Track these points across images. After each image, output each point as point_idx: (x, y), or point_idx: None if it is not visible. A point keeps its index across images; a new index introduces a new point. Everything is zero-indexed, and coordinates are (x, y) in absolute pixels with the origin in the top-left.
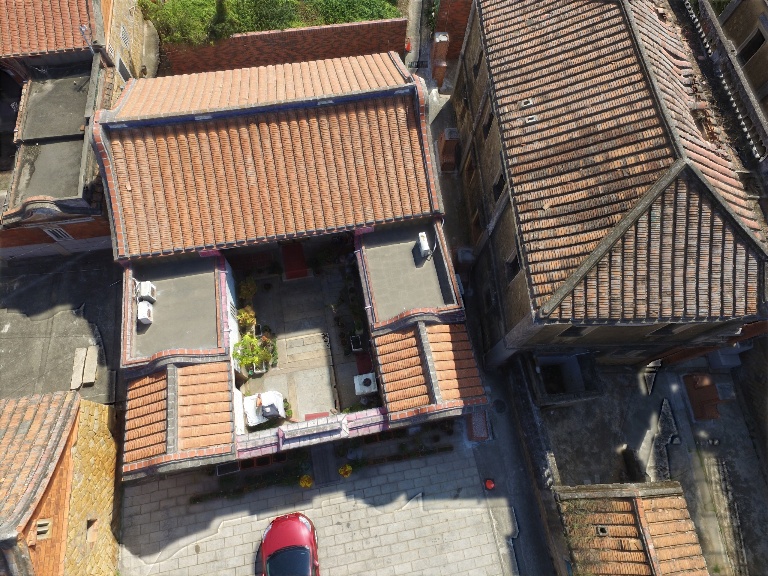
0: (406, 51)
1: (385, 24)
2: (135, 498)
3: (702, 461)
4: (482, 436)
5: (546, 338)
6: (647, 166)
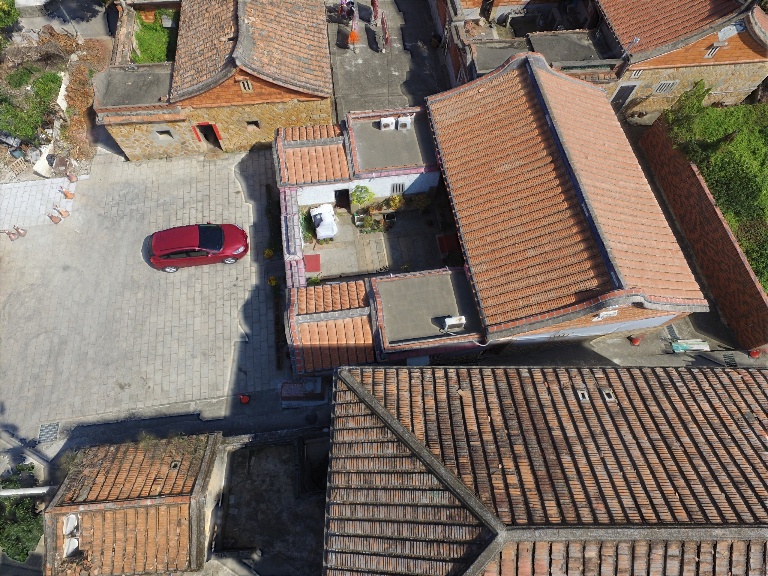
0: (749, 352)
1: (767, 312)
2: None
3: None
4: (283, 391)
5: None
6: (501, 493)
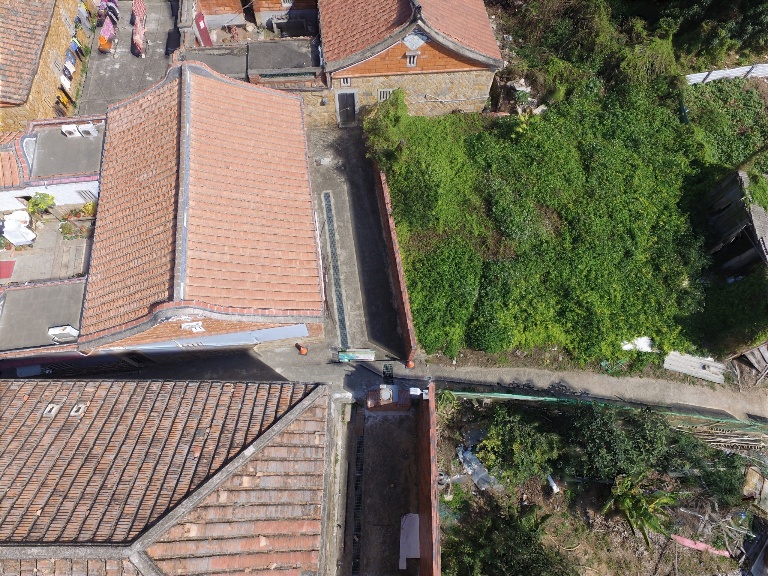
0: (407, 362)
1: None
2: None
3: None
4: None
5: None
6: None
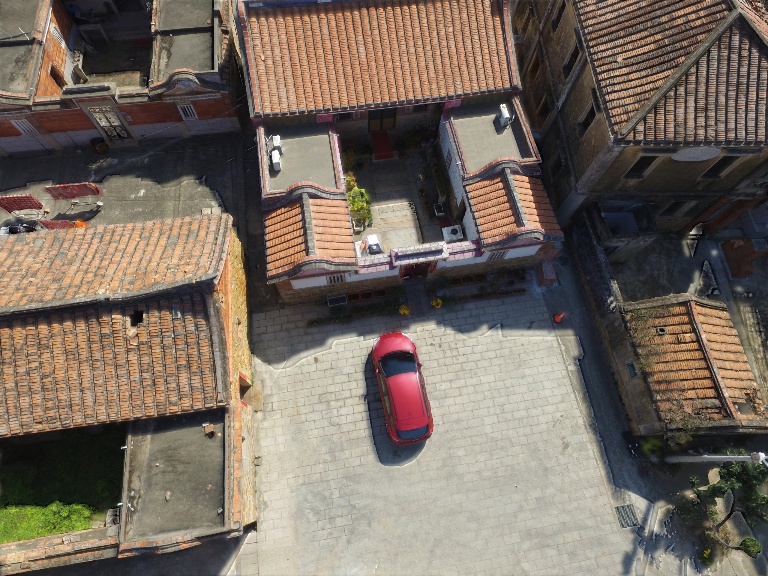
0: None
1: None
2: (261, 321)
3: (738, 308)
4: (551, 278)
5: (613, 180)
6: (706, 19)
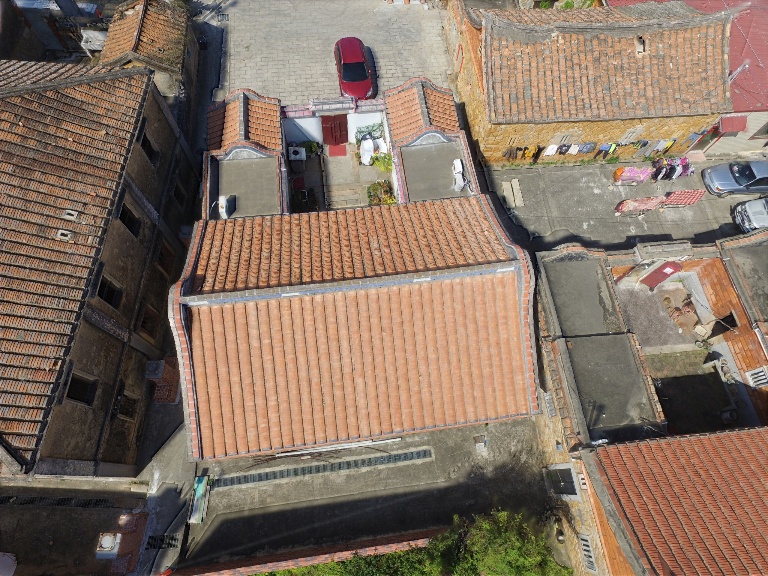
0: (173, 570)
1: (193, 575)
2: None
3: None
4: None
5: None
6: None
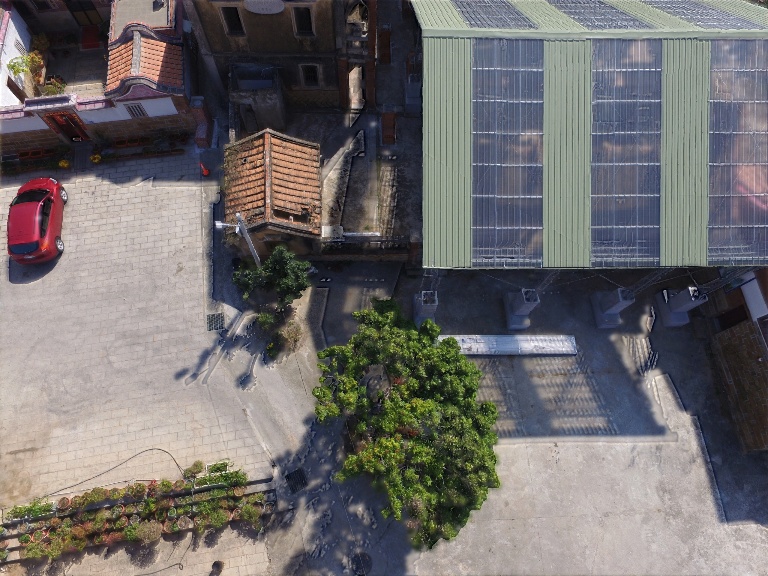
0: None
1: None
2: None
3: (379, 167)
4: (201, 137)
5: (222, 38)
6: None
